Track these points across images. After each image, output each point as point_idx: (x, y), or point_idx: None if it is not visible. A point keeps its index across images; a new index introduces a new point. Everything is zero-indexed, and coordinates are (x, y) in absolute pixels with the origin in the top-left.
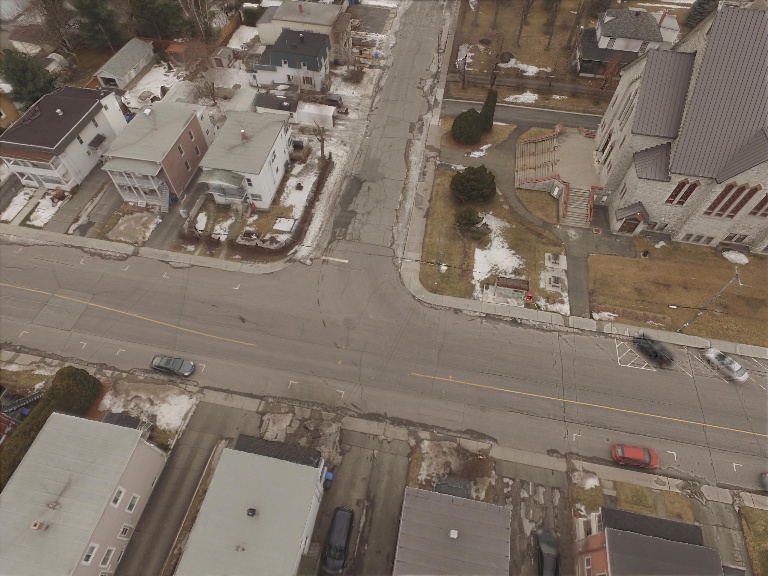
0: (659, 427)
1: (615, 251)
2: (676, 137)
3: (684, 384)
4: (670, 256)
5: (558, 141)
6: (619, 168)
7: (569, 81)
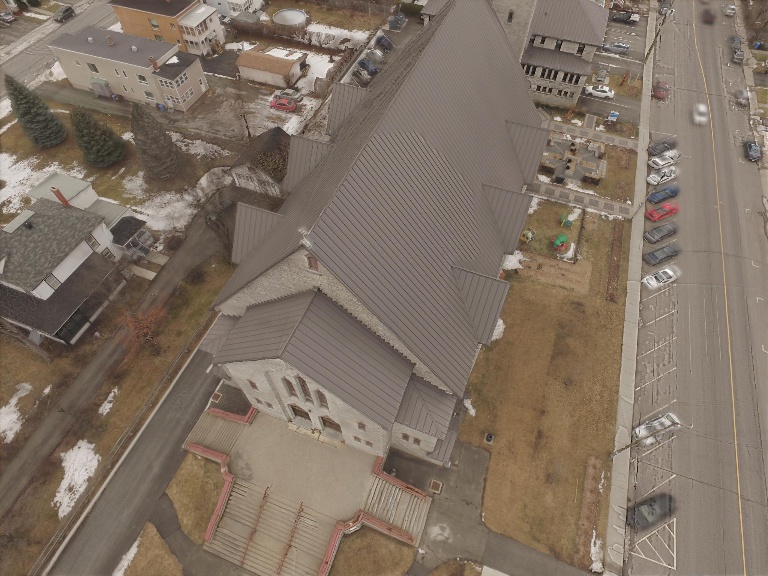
0: (759, 558)
1: (478, 477)
2: (413, 367)
3: (689, 491)
4: (491, 405)
5: (245, 478)
6: (386, 438)
7: (77, 367)
